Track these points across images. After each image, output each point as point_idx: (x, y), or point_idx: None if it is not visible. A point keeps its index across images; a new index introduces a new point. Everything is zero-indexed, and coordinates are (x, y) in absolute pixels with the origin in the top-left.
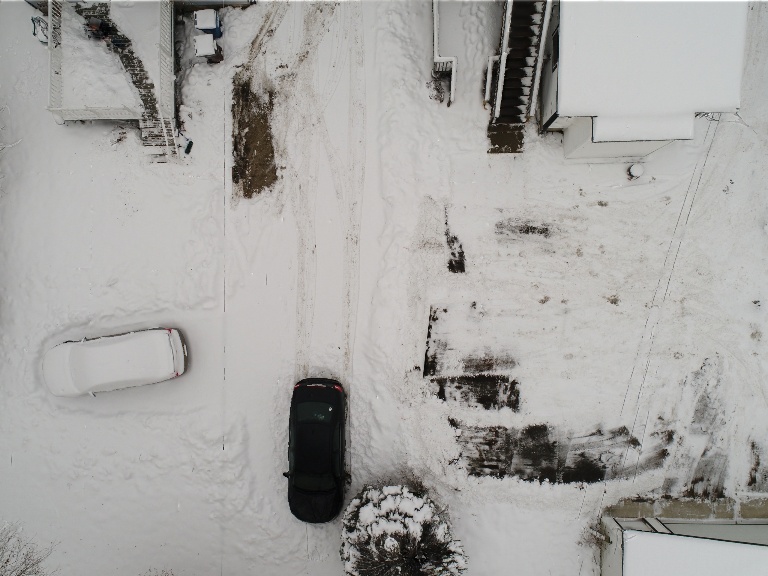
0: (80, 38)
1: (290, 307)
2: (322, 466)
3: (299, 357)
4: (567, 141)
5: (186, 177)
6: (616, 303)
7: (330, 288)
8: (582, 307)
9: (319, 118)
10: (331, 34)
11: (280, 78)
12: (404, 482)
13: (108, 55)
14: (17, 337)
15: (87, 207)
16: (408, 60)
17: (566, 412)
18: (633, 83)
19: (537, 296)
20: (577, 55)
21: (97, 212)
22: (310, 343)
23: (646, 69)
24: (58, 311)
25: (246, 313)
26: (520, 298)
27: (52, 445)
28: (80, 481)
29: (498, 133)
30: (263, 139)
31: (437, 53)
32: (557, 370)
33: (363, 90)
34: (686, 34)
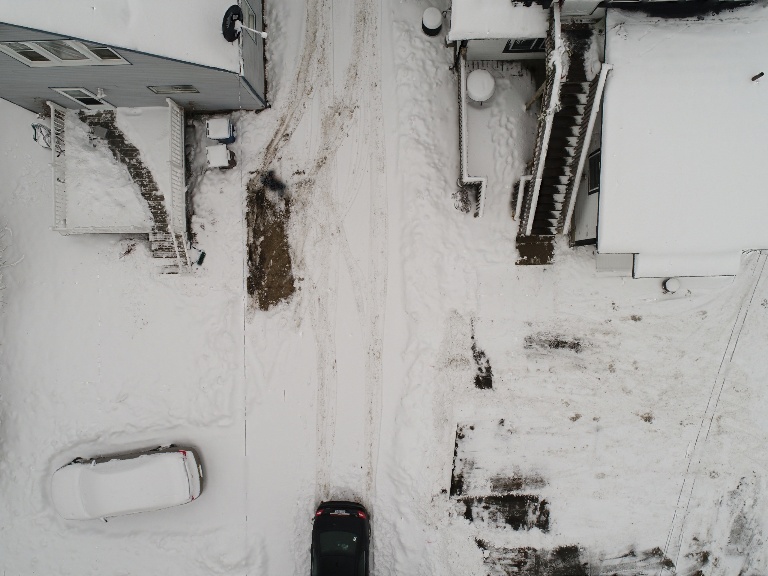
0: (85, 149)
1: (310, 425)
2: None
3: (320, 476)
4: (600, 256)
5: (198, 288)
6: (650, 421)
7: (351, 405)
8: (614, 425)
9: (338, 227)
10: (350, 139)
11: (297, 185)
12: None
13: (115, 166)
14: (23, 454)
15: (94, 319)
16: (432, 169)
17: (598, 533)
18: (678, 220)
19: (568, 413)
20: (620, 193)
21: (105, 324)
22: (331, 462)
23: (692, 206)
24: (66, 428)
25: (263, 430)
26: (550, 416)
27: (62, 567)
28: None
29: (527, 244)
30: (279, 248)
31: (466, 173)
32: (588, 490)
33: (384, 197)
34: (735, 171)
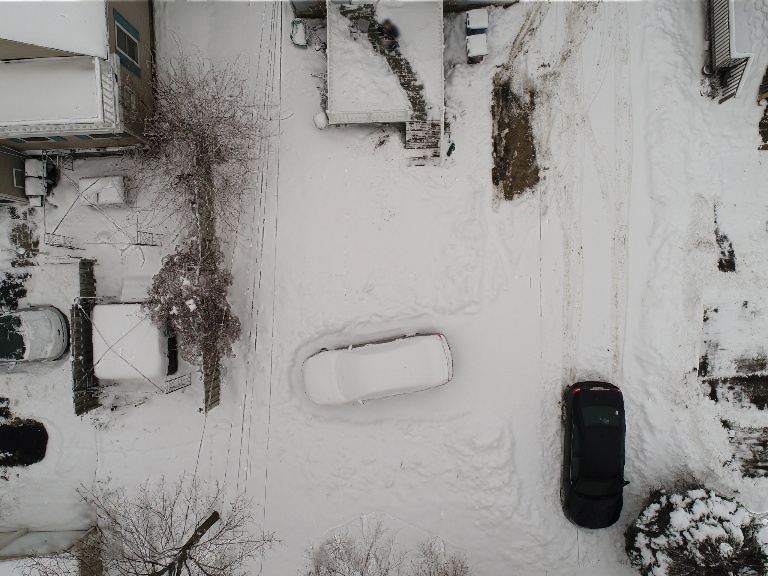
0: (350, 40)
1: (556, 310)
2: (611, 471)
3: (566, 360)
4: None
5: (444, 180)
6: None
7: (597, 290)
8: None
9: (583, 117)
10: (595, 32)
11: (542, 77)
12: (679, 485)
13: (377, 57)
14: (270, 346)
15: (341, 212)
16: (680, 57)
17: None
18: None
19: None
20: None
21: (351, 217)
22: (578, 346)
23: None
24: (313, 318)
25: (509, 317)
26: None
27: (309, 455)
28: (338, 490)
29: None
30: (524, 140)
31: (735, 49)
32: None
33: (627, 88)
34: None
